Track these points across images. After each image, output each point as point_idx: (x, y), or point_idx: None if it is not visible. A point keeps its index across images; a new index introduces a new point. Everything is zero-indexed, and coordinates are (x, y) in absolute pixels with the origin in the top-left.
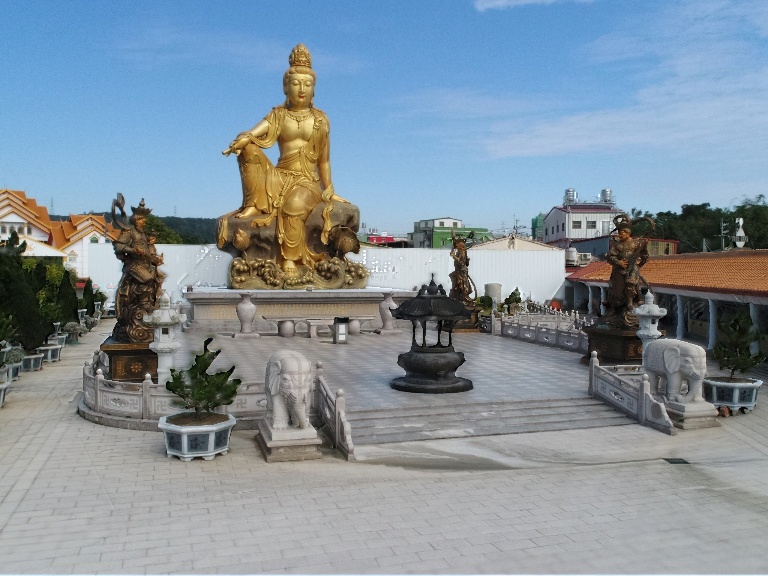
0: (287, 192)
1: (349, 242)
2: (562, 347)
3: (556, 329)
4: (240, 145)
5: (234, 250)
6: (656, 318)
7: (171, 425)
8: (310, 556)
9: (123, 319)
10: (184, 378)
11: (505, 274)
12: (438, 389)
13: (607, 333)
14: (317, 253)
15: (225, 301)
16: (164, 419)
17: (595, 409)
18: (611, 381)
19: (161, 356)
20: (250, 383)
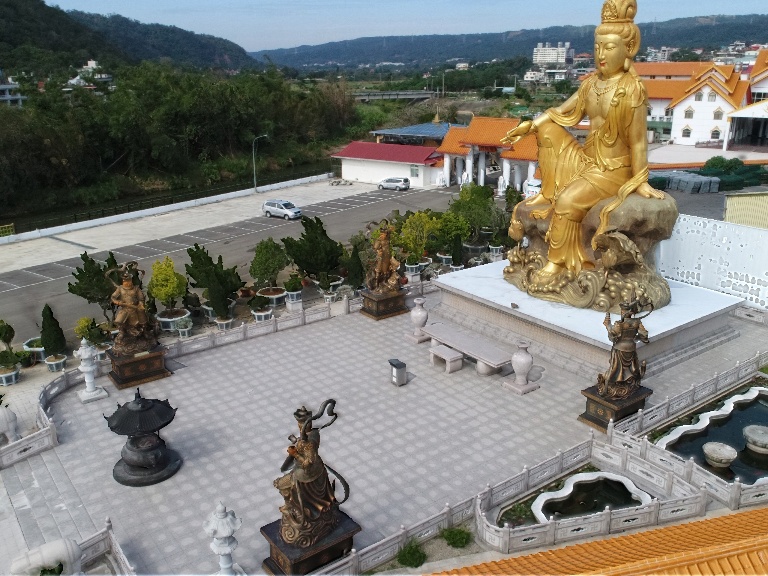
0: None
1: (607, 256)
2: None
3: None
4: (518, 132)
5: None
6: None
7: None
8: None
9: None
10: None
11: None
12: None
13: None
14: (594, 257)
15: None
16: None
17: None
18: None
19: None
20: None
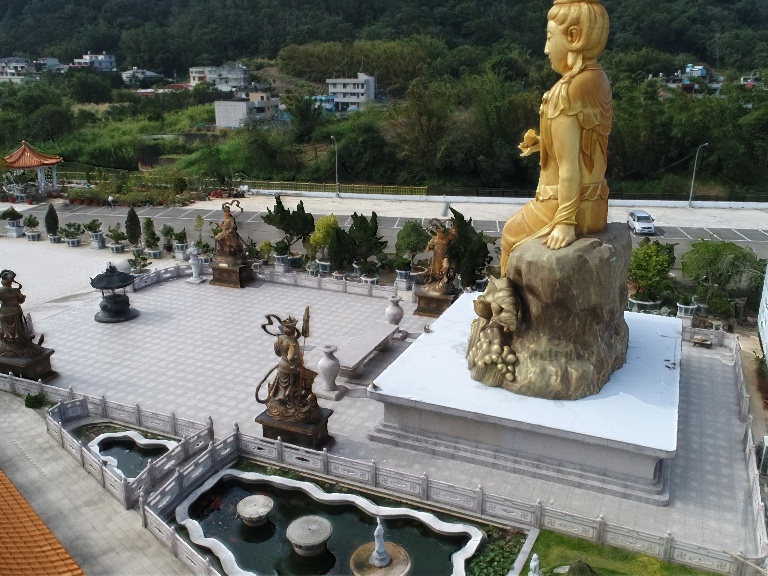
0: None
1: None
2: None
3: None
4: None
5: None
6: None
7: None
8: (69, 276)
9: None
10: None
11: None
12: None
13: None
14: None
15: None
16: None
17: None
18: None
19: None
20: (149, 274)
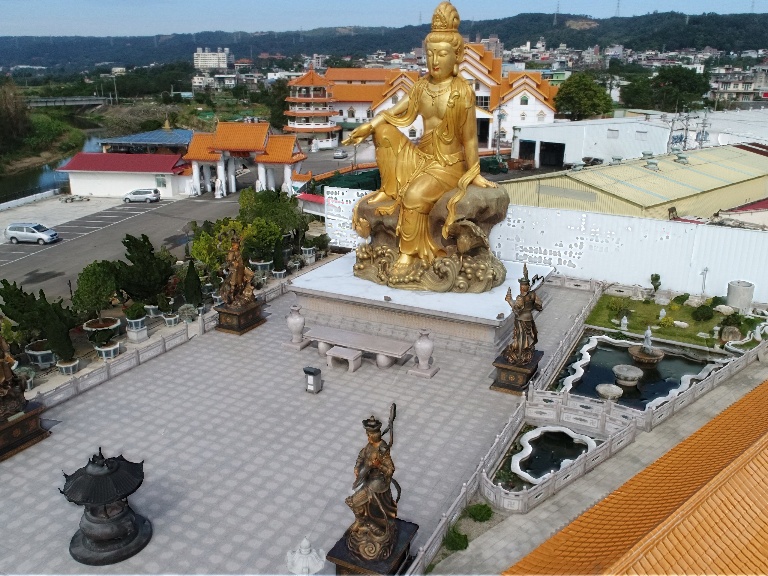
0: (413, 179)
1: (463, 242)
2: None
3: None
4: (359, 133)
5: None
6: None
7: None
8: None
9: None
10: None
11: None
12: (76, 555)
13: None
14: (443, 245)
15: (316, 296)
16: None
17: None
18: None
19: None
20: None
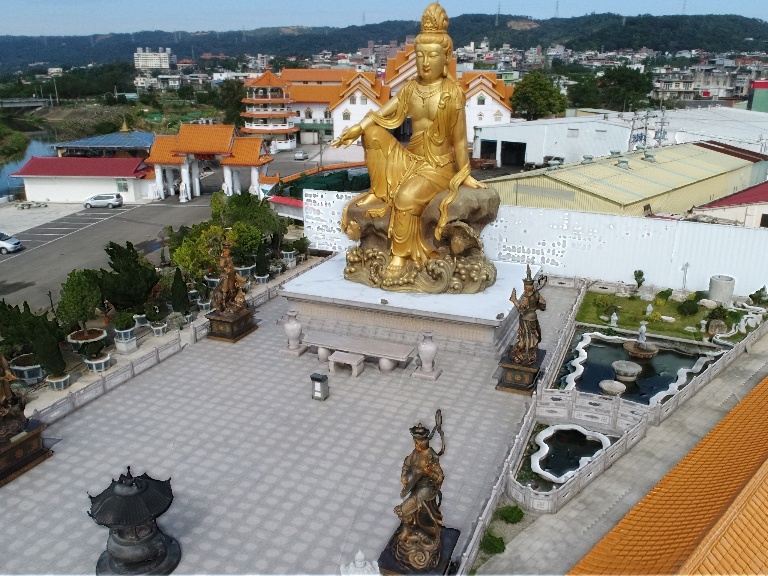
0: (404, 181)
1: (457, 243)
2: None
3: None
4: (350, 135)
5: None
6: None
7: None
8: None
9: None
10: None
11: (759, 262)
12: None
13: None
14: (435, 246)
15: (310, 301)
16: None
17: None
18: None
19: None
20: None
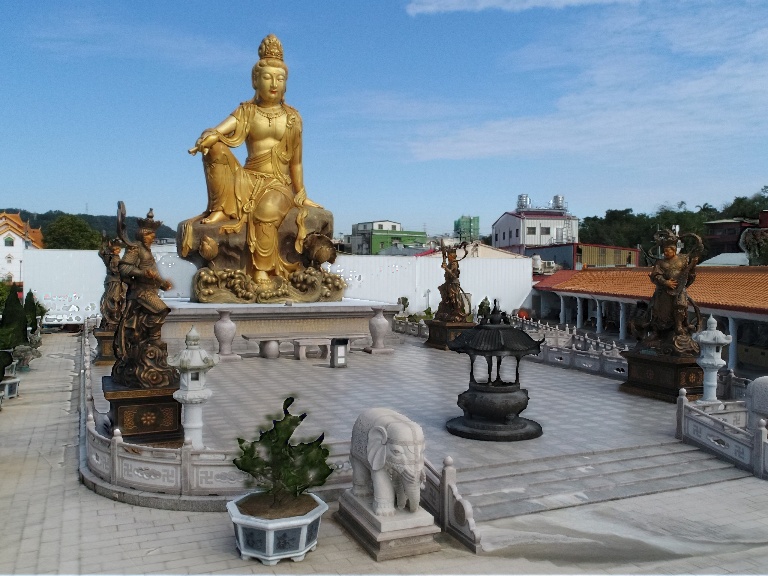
0: (258, 196)
1: (326, 251)
2: (579, 369)
3: (571, 349)
4: (208, 143)
5: (199, 259)
6: (720, 345)
7: (251, 518)
8: None
9: (132, 359)
10: (259, 452)
11: (473, 283)
12: (511, 436)
13: (655, 360)
14: (290, 263)
15: (196, 317)
16: (234, 507)
17: (697, 458)
18: (710, 424)
19: (189, 408)
20: None
